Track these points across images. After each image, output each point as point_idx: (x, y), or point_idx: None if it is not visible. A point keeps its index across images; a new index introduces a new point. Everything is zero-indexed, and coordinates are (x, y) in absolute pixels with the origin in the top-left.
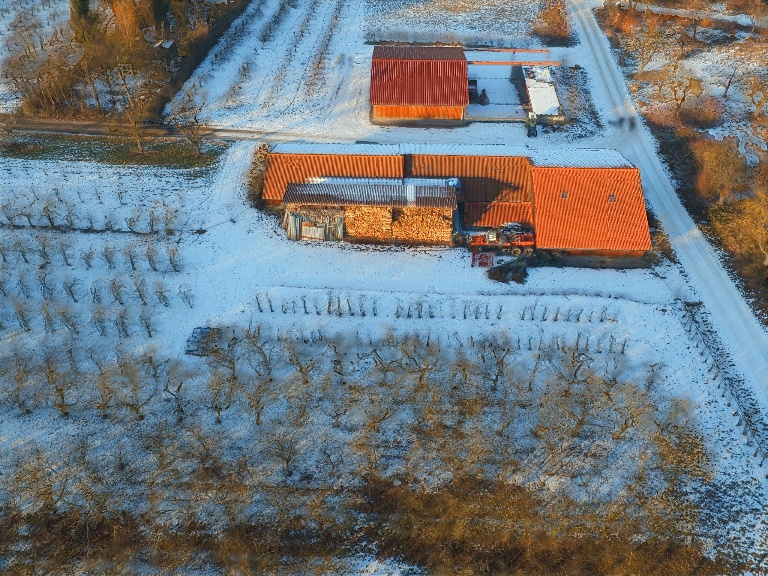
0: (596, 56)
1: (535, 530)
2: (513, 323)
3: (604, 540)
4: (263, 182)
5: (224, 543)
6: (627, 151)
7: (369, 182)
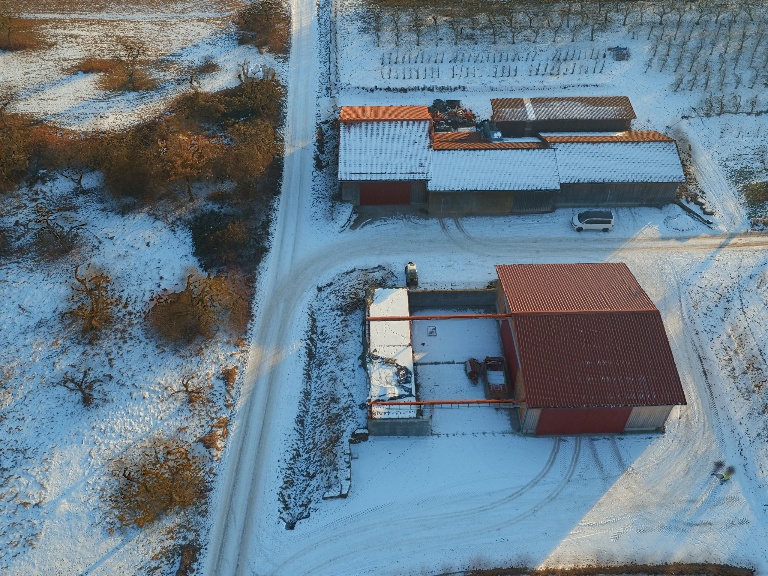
0: None
1: (439, 8)
2: (444, 76)
3: (412, 7)
4: None
5: (558, 0)
6: (302, 255)
7: (571, 135)
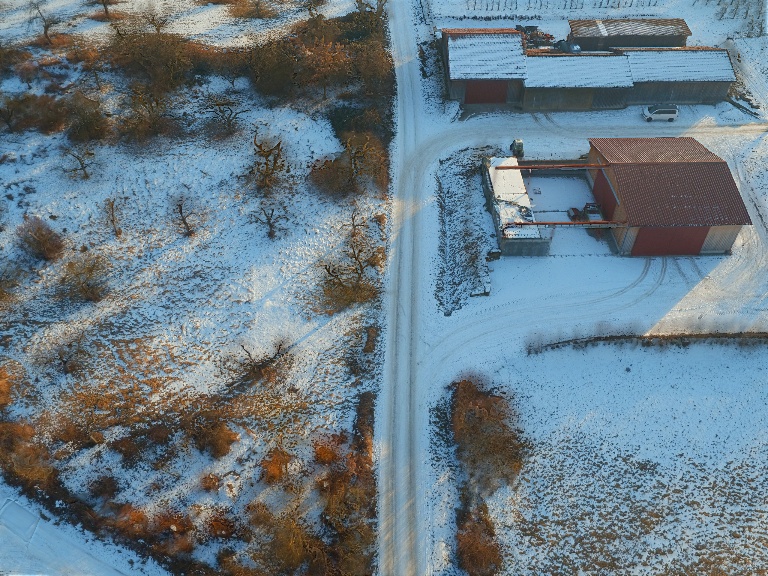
0: (411, 356)
1: None
2: (521, 8)
3: None
4: None
5: None
6: (423, 138)
7: None
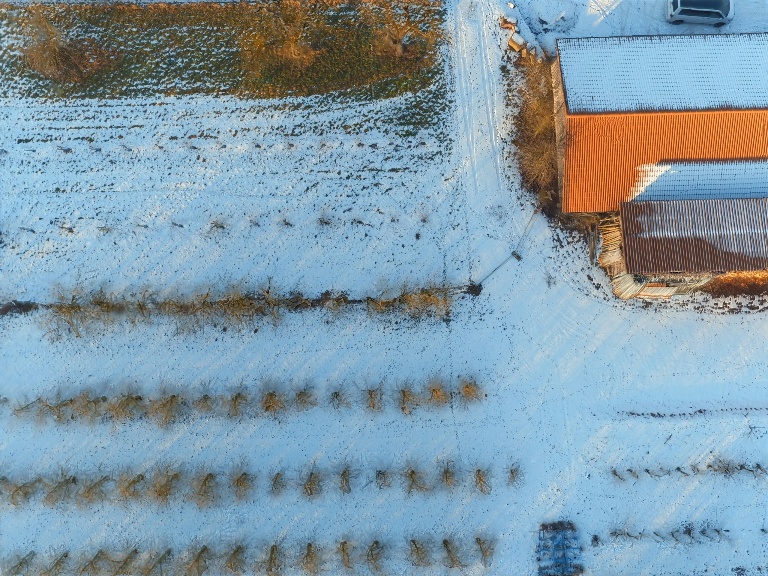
0: None
1: None
2: None
3: None
4: (551, 159)
5: None
6: None
7: (746, 168)
